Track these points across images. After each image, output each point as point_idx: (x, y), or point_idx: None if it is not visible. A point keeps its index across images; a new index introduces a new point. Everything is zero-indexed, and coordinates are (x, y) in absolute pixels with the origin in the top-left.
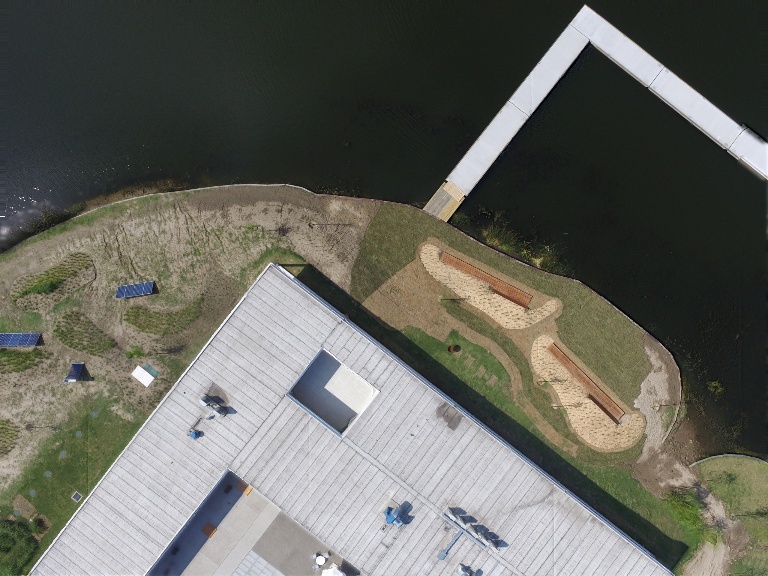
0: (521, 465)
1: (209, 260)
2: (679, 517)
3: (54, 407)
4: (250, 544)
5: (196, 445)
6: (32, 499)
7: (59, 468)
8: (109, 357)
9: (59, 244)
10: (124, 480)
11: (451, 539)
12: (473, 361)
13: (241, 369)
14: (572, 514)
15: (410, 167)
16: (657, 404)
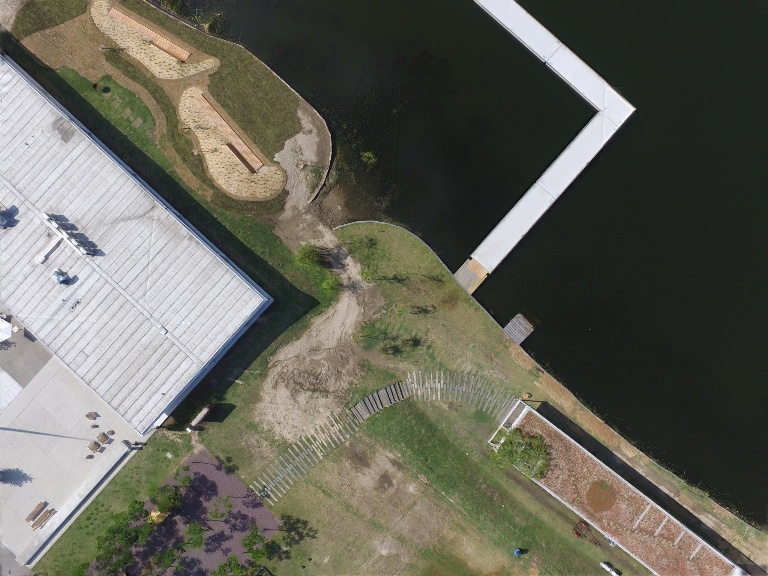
0: (126, 180)
1: None
2: (315, 275)
3: None
4: None
5: None
6: None
7: None
8: None
9: None
10: None
11: (51, 244)
12: (120, 103)
13: None
14: (170, 231)
15: None
16: (301, 163)
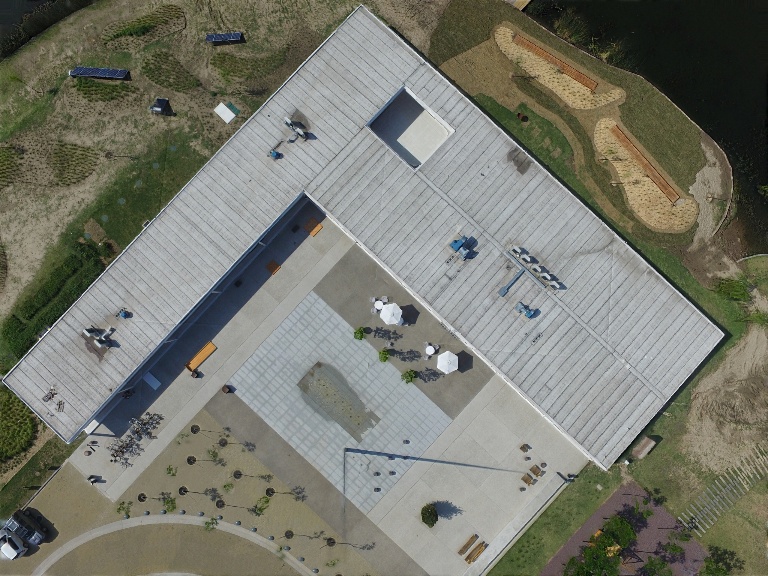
0: (584, 213)
1: (296, 17)
2: (725, 307)
3: (135, 138)
4: (311, 284)
5: (275, 166)
6: (104, 224)
7: (133, 196)
8: (193, 94)
9: None
10: (202, 193)
11: (512, 277)
12: (539, 132)
13: (325, 99)
14: (630, 265)
15: None
16: (710, 196)
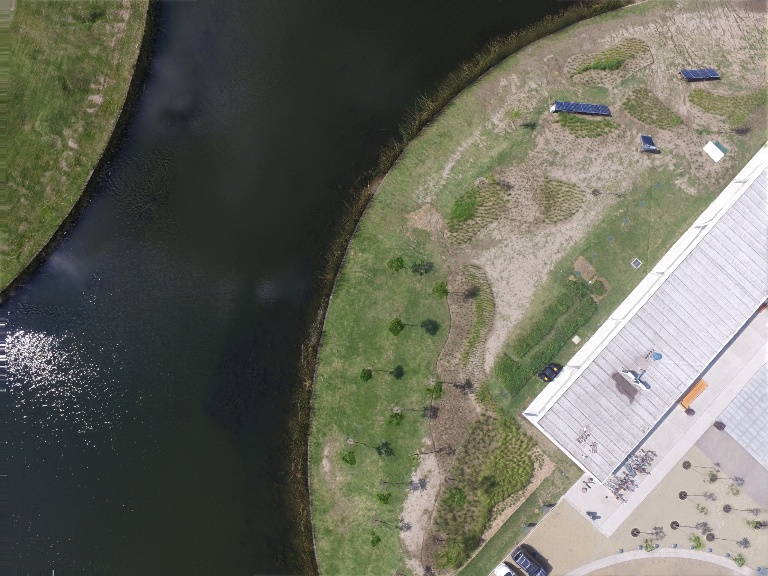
0: None
1: (767, 54)
2: None
3: (620, 175)
4: None
5: None
6: (593, 262)
7: (622, 234)
8: (679, 132)
9: (612, 29)
10: (726, 235)
11: None
12: None
13: None
14: None
15: None
16: None
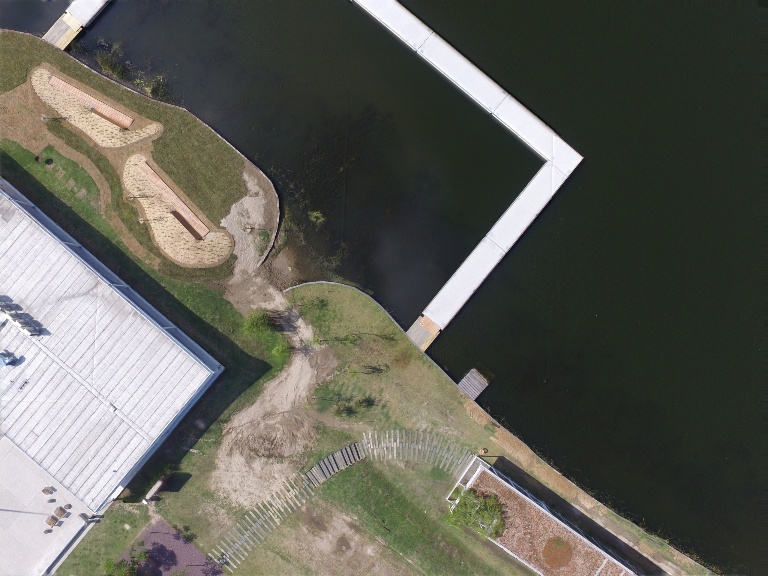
0: (68, 257)
1: None
2: (267, 339)
3: None
4: None
5: None
6: None
7: None
8: None
9: None
10: None
11: None
12: (64, 174)
13: None
14: (115, 307)
15: (37, 1)
16: (248, 226)
